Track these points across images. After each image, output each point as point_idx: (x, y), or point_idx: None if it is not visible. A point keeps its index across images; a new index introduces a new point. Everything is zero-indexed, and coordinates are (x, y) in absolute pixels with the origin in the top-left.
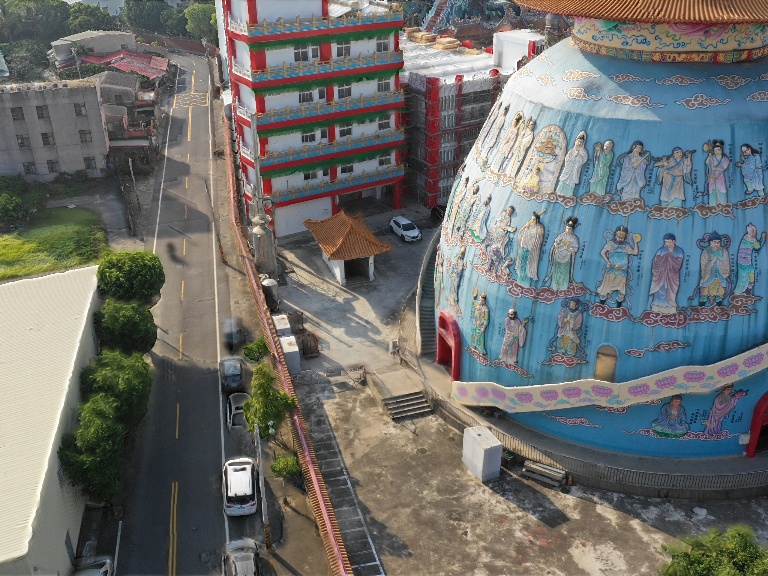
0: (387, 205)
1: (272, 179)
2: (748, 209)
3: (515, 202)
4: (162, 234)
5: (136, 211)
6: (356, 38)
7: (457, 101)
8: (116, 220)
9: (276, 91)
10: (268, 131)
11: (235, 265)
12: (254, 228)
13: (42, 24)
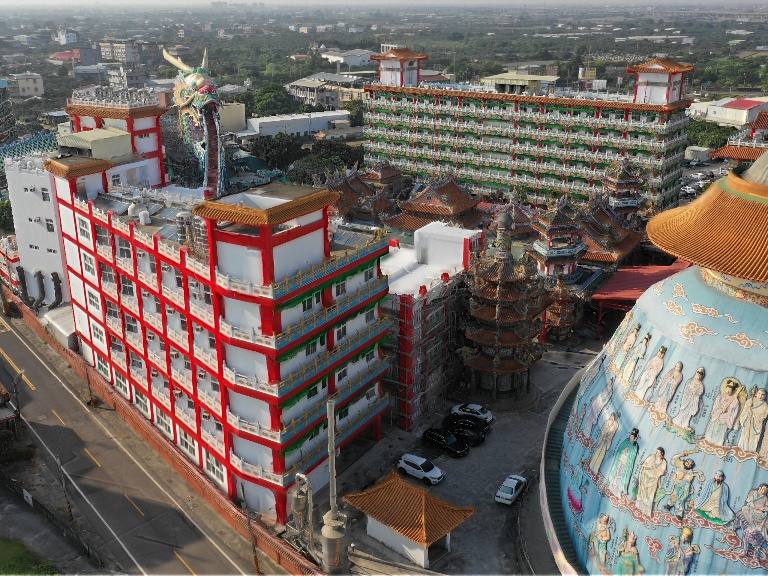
0: (364, 437)
1: (286, 452)
2: None
3: (767, 479)
4: (137, 552)
5: (66, 522)
6: (352, 273)
7: (423, 313)
8: (52, 545)
9: (294, 353)
10: (288, 400)
11: (277, 575)
12: (323, 531)
13: None
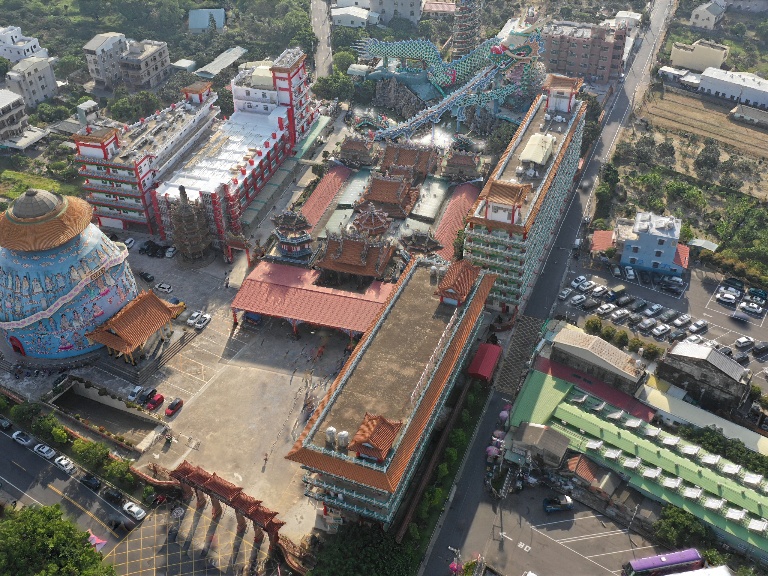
0: (154, 230)
1: None
2: (2, 287)
3: None
4: None
5: None
6: None
7: None
8: None
9: (89, 178)
10: (88, 190)
11: None
12: None
13: (282, 37)
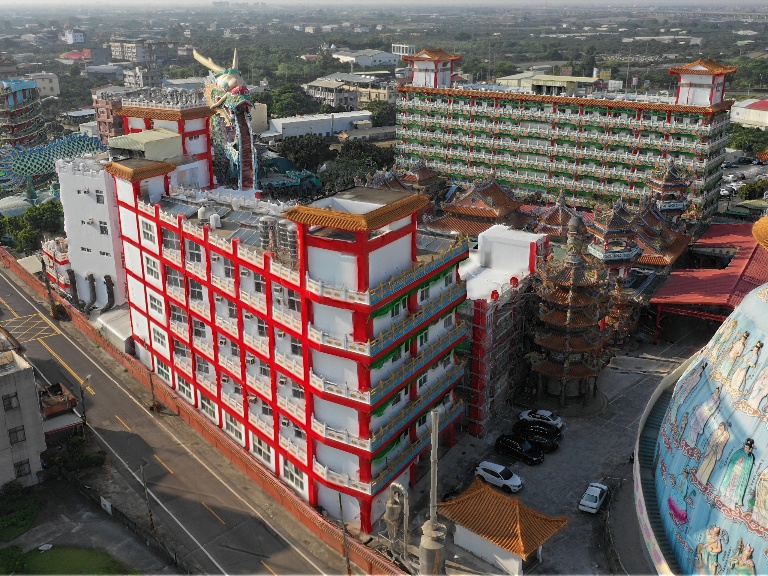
0: None
1: (373, 460)
2: None
3: None
4: (224, 561)
5: (147, 531)
6: (435, 278)
7: (495, 318)
8: (137, 555)
9: (385, 359)
10: (378, 408)
11: None
12: (422, 542)
13: None
